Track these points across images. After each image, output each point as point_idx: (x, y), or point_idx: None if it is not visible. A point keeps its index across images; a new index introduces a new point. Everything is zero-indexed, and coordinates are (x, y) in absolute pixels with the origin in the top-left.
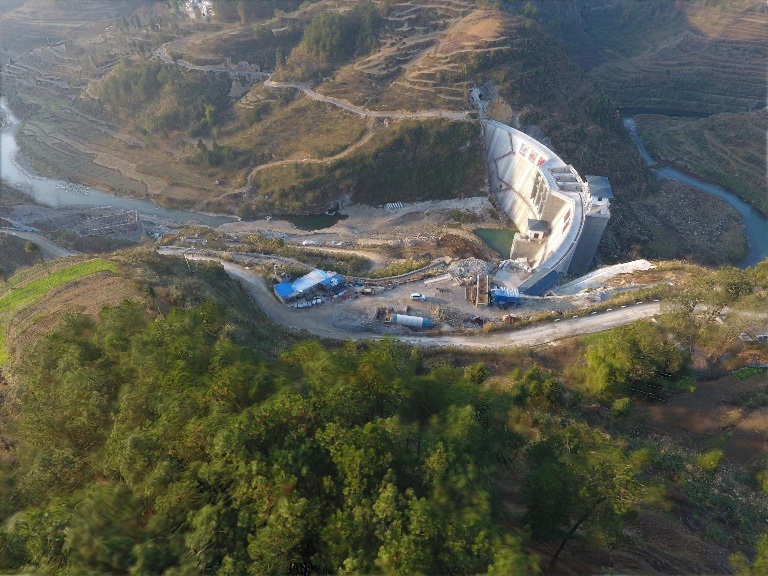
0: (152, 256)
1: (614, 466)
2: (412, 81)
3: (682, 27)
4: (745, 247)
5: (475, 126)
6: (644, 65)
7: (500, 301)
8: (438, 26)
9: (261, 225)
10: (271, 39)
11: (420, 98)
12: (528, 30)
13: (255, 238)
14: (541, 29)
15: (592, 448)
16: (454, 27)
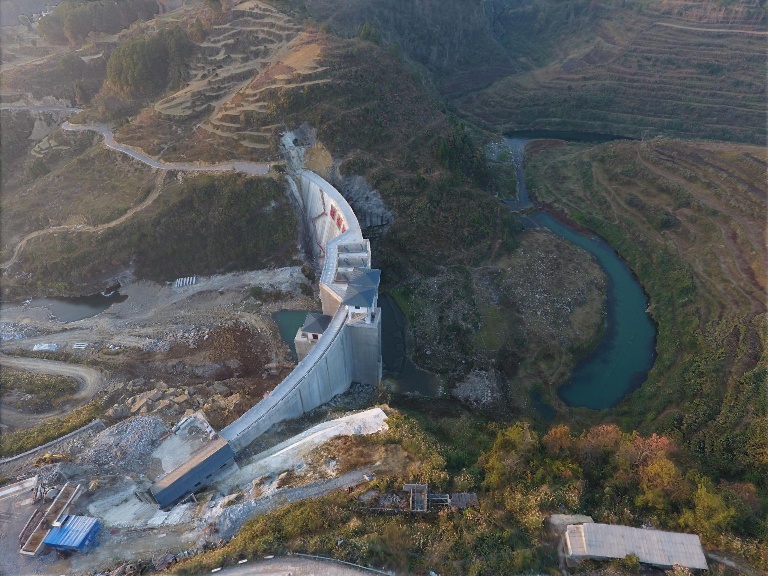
0: None
1: None
2: (215, 124)
3: (595, 33)
4: (598, 329)
5: (277, 183)
6: (545, 80)
7: (56, 547)
8: (260, 53)
9: (10, 315)
10: (81, 69)
11: (221, 146)
12: (357, 57)
13: None
14: (378, 54)
15: None
16: (276, 54)
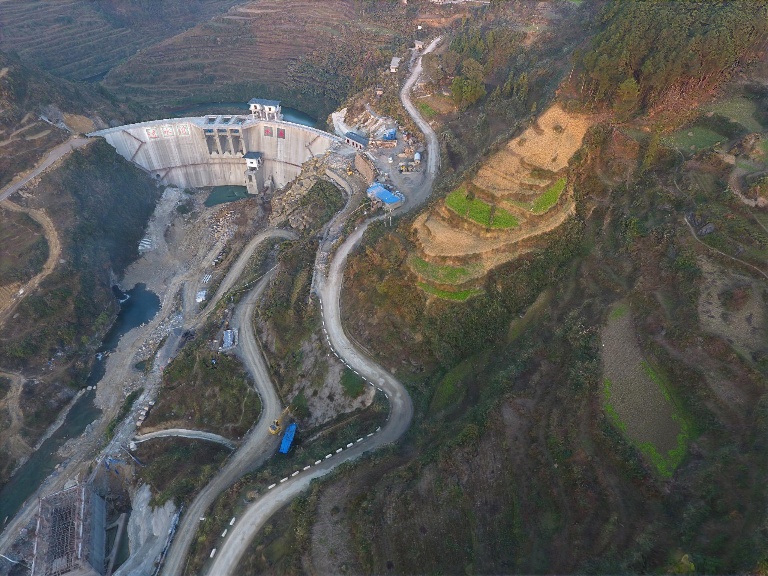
0: None
1: None
2: None
3: None
4: None
5: (104, 140)
6: None
7: None
8: None
9: (122, 359)
10: None
11: (16, 153)
12: None
13: (234, 293)
14: None
15: None
16: None
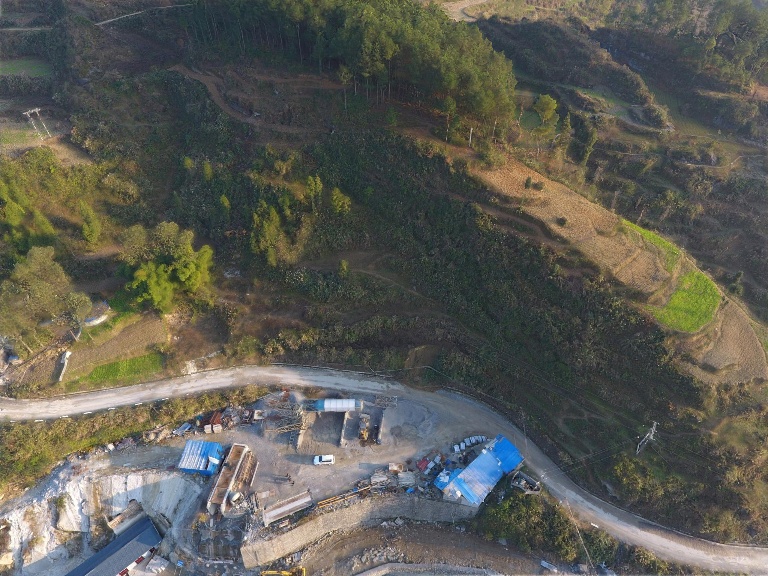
0: (700, 434)
1: (317, 19)
2: None
3: None
4: None
5: None
6: None
7: None
8: None
9: None
10: None
11: None
12: None
13: None
14: None
15: (265, 167)
16: None
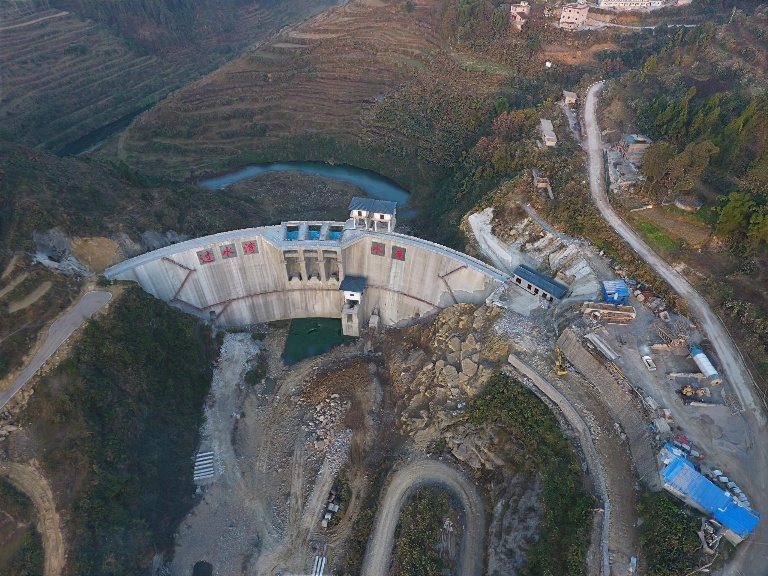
0: None
1: None
2: None
3: None
4: (347, 183)
5: (136, 287)
6: None
7: None
8: None
9: None
10: None
11: None
12: None
13: None
14: None
15: None
16: None
